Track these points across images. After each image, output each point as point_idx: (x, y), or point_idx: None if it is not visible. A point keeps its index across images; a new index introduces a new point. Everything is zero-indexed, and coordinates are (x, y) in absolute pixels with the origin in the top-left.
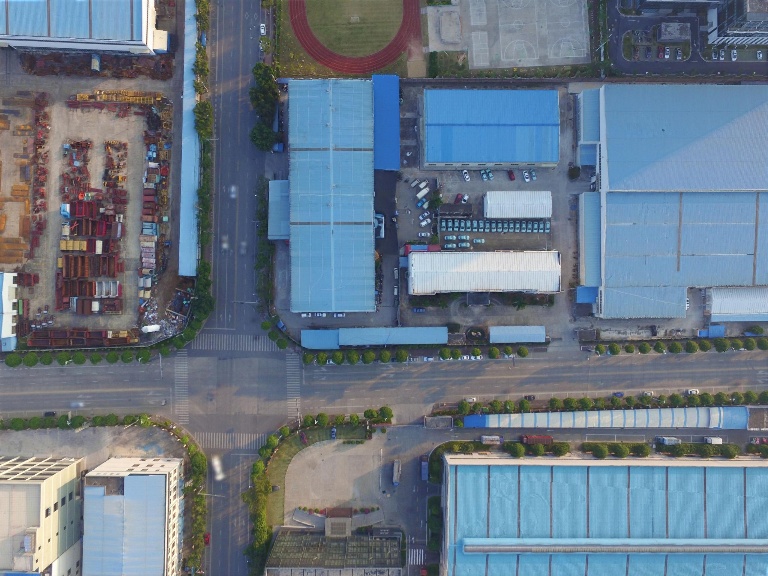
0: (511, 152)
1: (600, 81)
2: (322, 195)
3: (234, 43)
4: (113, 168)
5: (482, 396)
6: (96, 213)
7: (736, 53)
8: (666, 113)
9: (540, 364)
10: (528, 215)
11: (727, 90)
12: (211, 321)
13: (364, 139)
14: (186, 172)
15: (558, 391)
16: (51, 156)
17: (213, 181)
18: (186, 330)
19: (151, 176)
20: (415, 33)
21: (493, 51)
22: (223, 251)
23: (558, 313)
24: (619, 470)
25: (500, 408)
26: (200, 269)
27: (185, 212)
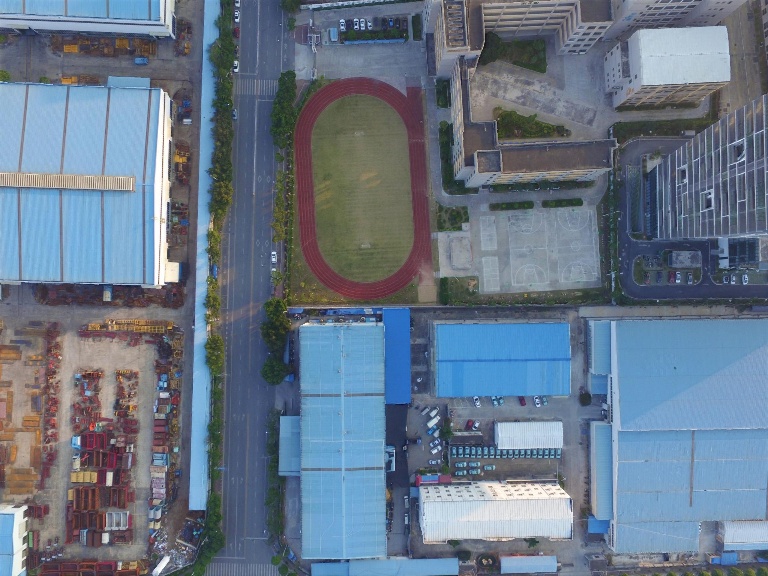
0: (522, 386)
1: (611, 306)
2: (333, 441)
3: (245, 270)
4: (124, 397)
5: None
6: (107, 443)
7: (747, 277)
8: (678, 350)
9: None
10: (539, 446)
11: (739, 325)
12: (221, 550)
13: (375, 384)
14: (197, 406)
15: None
16: (62, 386)
17: (224, 409)
18: (196, 568)
19: (162, 407)
20: (426, 258)
21: (504, 276)
22: (233, 479)
23: None
24: None
25: None
26: (210, 504)
27: (196, 446)
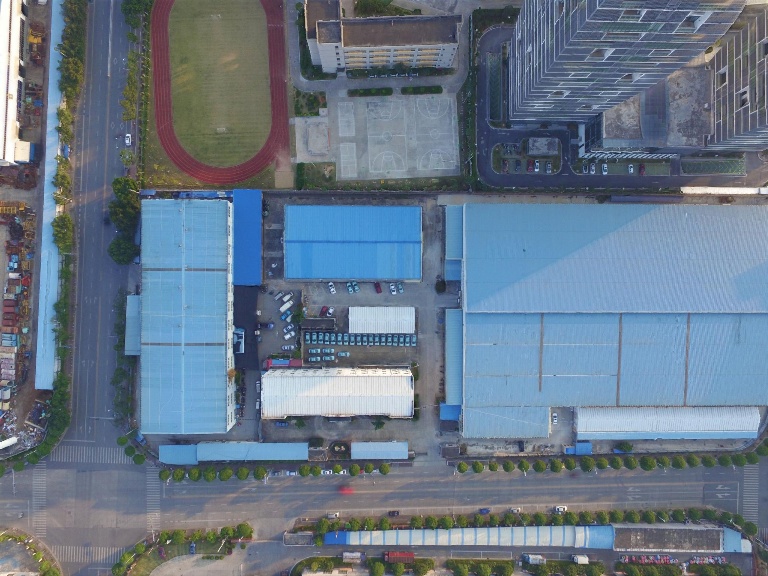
0: (372, 269)
1: (469, 194)
2: (173, 316)
3: (99, 153)
4: None
5: (346, 511)
6: None
7: (607, 167)
8: (528, 233)
9: (405, 479)
10: (391, 331)
11: (591, 209)
12: (71, 433)
13: (217, 259)
14: (45, 285)
15: (423, 506)
16: None
17: (75, 292)
18: (39, 446)
19: (11, 287)
20: (283, 143)
21: (361, 162)
22: (84, 362)
23: (424, 427)
24: None
25: None
26: (56, 383)
27: None
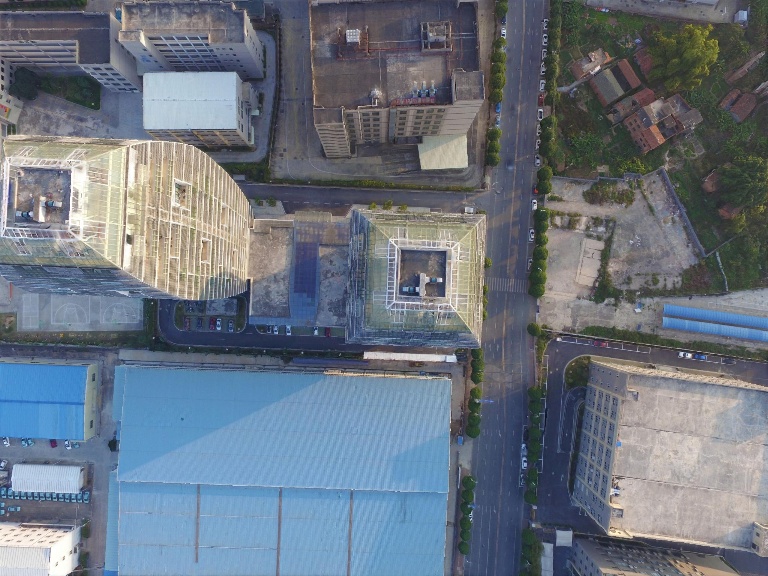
0: (34, 429)
1: None
2: None
3: None
4: None
5: None
6: None
7: (291, 328)
8: (188, 400)
9: None
10: (54, 491)
11: (255, 378)
12: None
13: None
14: None
15: None
16: None
17: None
18: None
19: None
20: None
21: (43, 314)
22: None
23: None
24: None
25: None
26: None
27: None
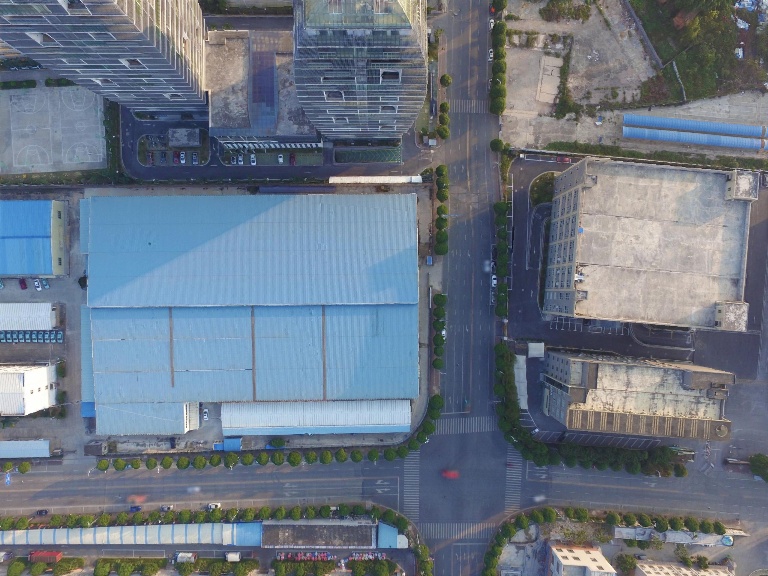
0: (2, 265)
1: (114, 187)
2: None
3: None
4: None
5: None
6: None
7: (255, 157)
8: (154, 226)
9: (54, 477)
10: (26, 328)
11: (221, 201)
12: None
13: None
14: None
15: (74, 505)
16: None
17: None
18: None
19: None
20: None
21: (5, 157)
22: None
23: (73, 425)
24: None
25: None
26: None
27: None
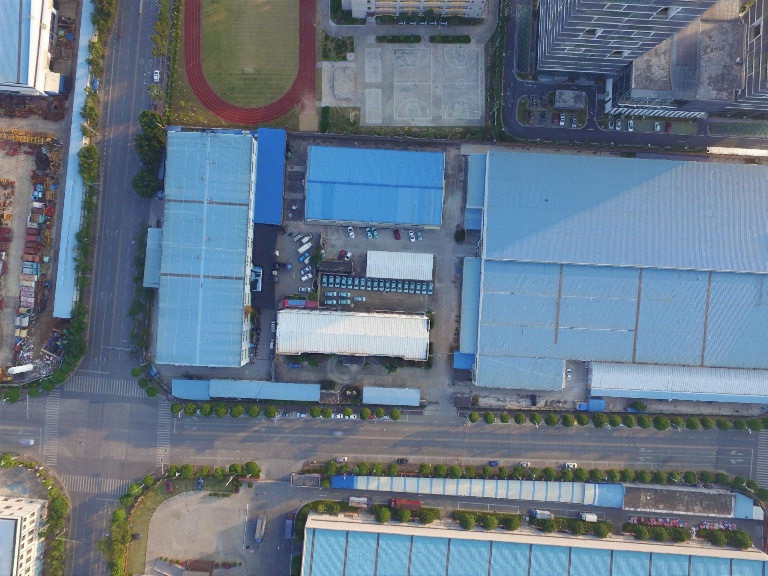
0: (393, 213)
1: (492, 144)
2: (193, 248)
3: (127, 88)
4: None
5: (354, 456)
6: None
7: (633, 124)
8: (551, 183)
9: (415, 427)
10: (408, 277)
11: (615, 163)
12: (86, 363)
13: (240, 194)
14: (68, 214)
15: (432, 456)
16: None
17: (97, 224)
18: (55, 373)
19: (34, 216)
20: (309, 87)
21: (386, 109)
22: (102, 294)
23: (437, 376)
24: (481, 544)
25: (370, 470)
26: (74, 312)
27: (64, 254)
